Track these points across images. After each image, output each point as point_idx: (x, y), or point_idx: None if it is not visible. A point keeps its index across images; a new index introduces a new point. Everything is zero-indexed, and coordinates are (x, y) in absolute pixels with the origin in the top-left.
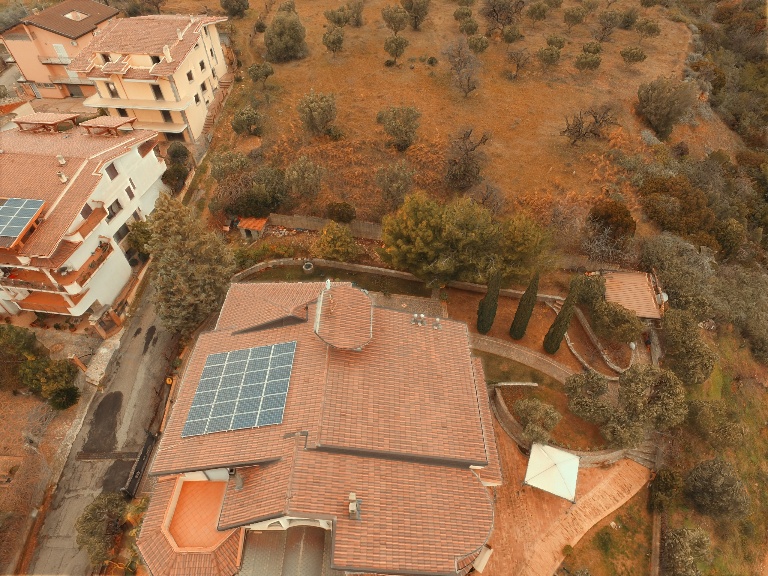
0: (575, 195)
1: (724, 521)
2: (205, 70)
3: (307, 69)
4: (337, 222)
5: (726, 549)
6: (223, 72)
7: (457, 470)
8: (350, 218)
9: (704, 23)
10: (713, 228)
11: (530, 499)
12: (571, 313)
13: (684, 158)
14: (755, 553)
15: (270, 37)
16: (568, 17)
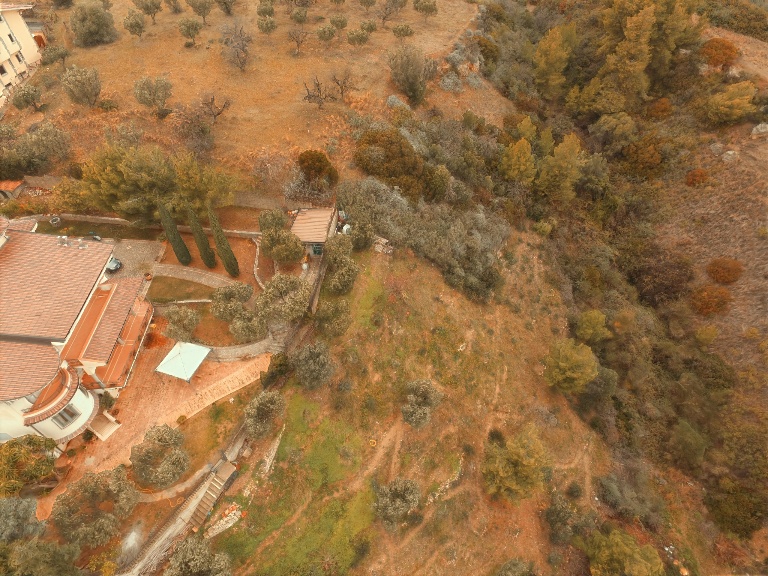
0: (297, 149)
1: (343, 397)
2: None
3: (111, 52)
4: (79, 180)
5: (337, 417)
6: (36, 58)
7: (38, 346)
8: None
9: (500, 4)
10: (424, 174)
11: (172, 387)
12: (219, 235)
13: (432, 119)
14: (373, 422)
15: (74, 23)
16: None
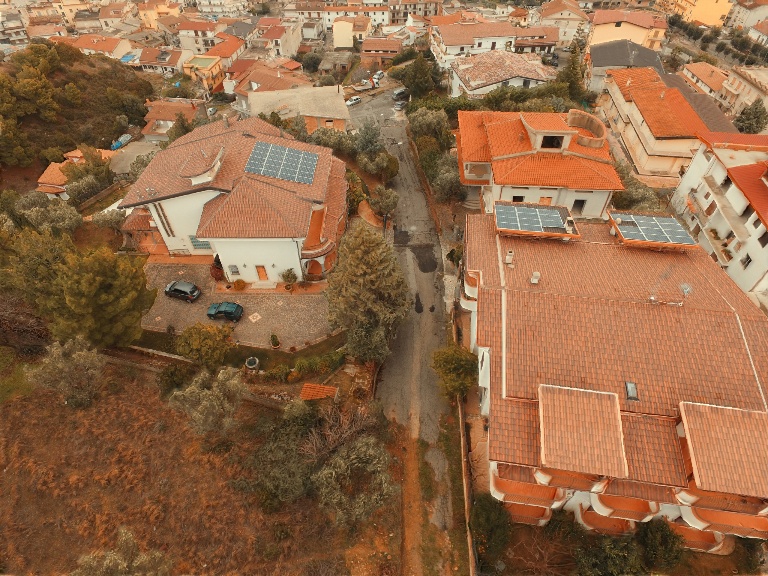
0: None
1: None
2: None
3: None
4: None
5: None
6: None
7: None
8: None
9: None
10: None
11: None
12: None
13: None
14: None
15: None
16: None
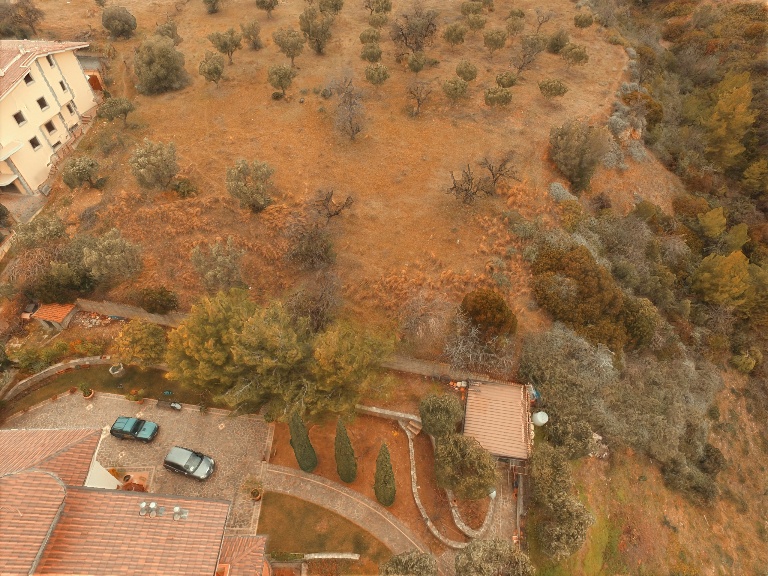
0: (451, 275)
1: None
2: (48, 108)
3: (182, 103)
4: (152, 313)
5: None
6: (90, 105)
7: None
8: (166, 309)
9: (646, 45)
10: (622, 311)
11: None
12: (387, 475)
13: (603, 213)
14: None
15: (138, 66)
16: (487, 41)
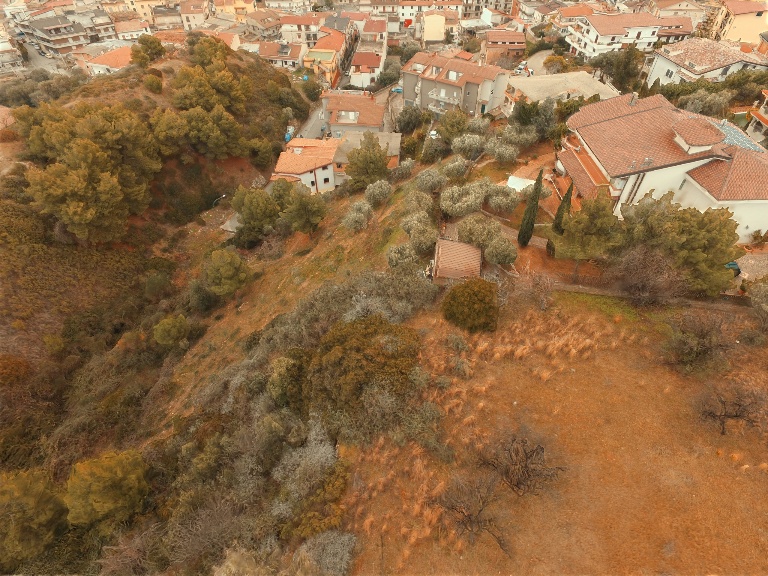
0: (516, 349)
1: None
2: None
3: None
4: None
5: None
6: None
7: None
8: None
9: None
10: None
11: None
12: None
13: None
14: None
15: None
16: None
